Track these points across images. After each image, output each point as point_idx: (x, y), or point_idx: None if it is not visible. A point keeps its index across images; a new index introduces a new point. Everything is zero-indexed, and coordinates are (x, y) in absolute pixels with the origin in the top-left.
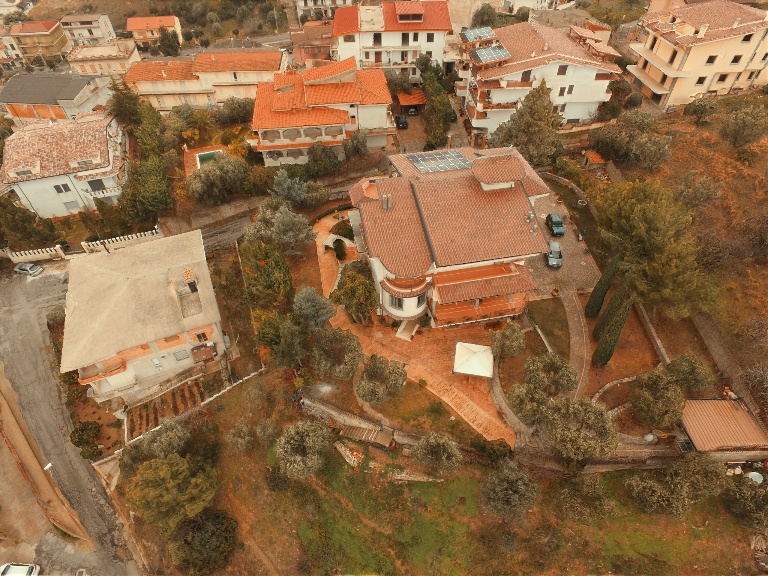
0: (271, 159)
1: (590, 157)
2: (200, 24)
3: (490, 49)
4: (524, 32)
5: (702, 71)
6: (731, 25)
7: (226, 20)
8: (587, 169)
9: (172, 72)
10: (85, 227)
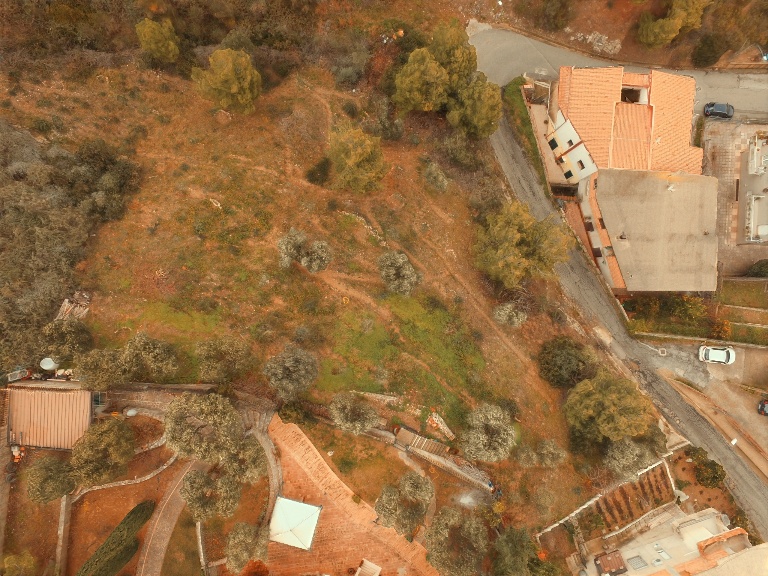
0: None
1: None
2: None
3: None
4: None
5: None
6: None
7: None
8: None
9: None
10: None
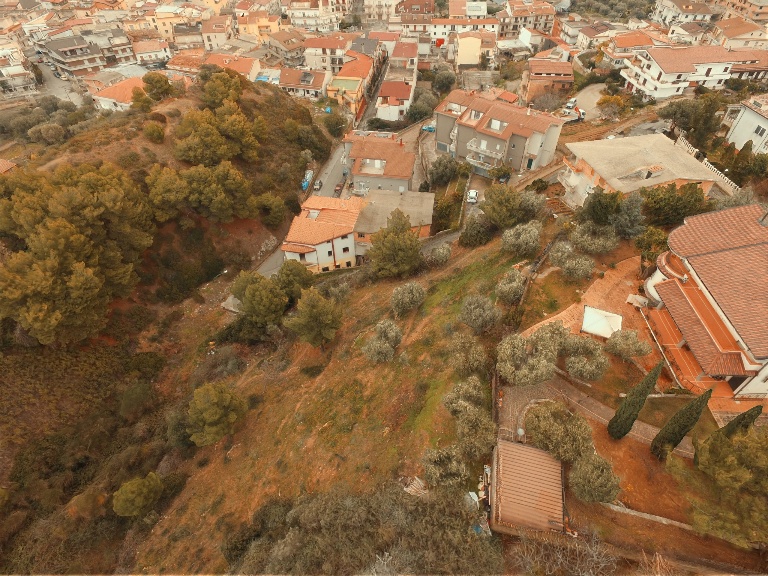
0: None
1: None
2: None
3: None
4: None
5: None
6: None
7: None
8: None
9: None
10: (723, 154)
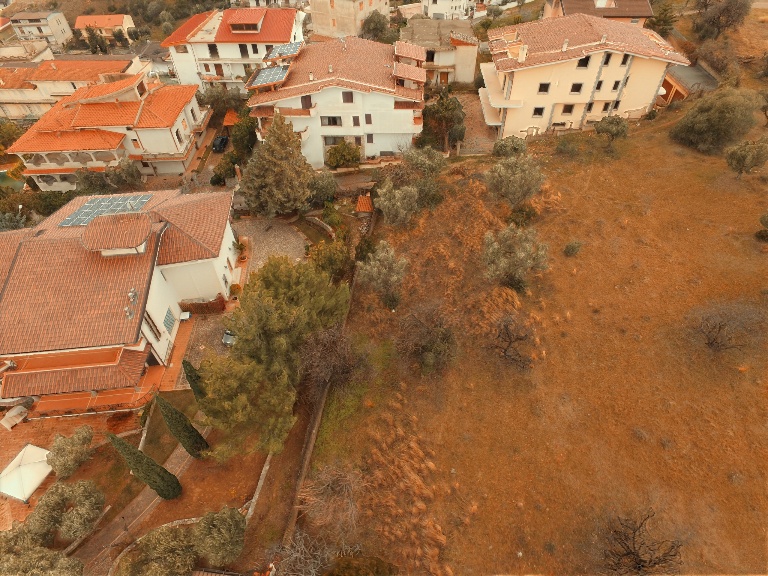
0: (45, 183)
1: (359, 203)
2: (155, 23)
3: (274, 69)
4: (334, 49)
5: (536, 101)
6: (562, 47)
7: (181, 19)
8: (357, 217)
9: (13, 80)
10: None
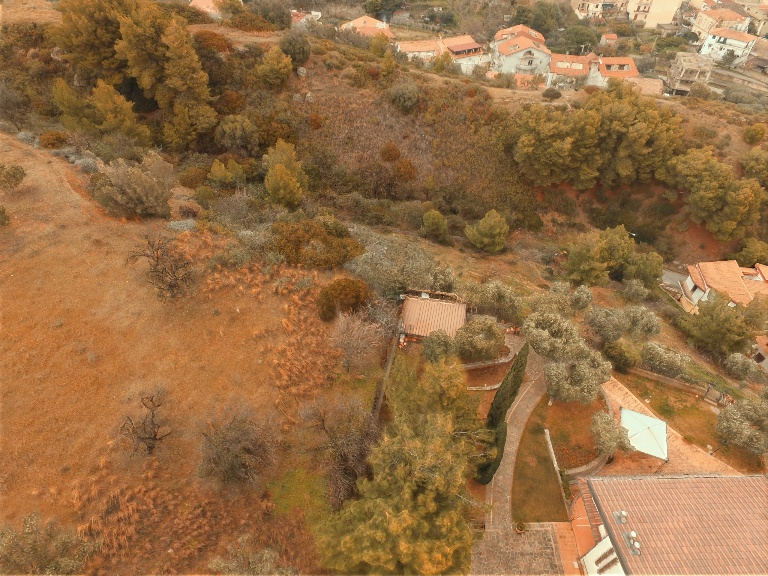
0: None
1: None
2: None
3: None
4: None
5: None
6: None
7: None
8: None
9: None
10: None
